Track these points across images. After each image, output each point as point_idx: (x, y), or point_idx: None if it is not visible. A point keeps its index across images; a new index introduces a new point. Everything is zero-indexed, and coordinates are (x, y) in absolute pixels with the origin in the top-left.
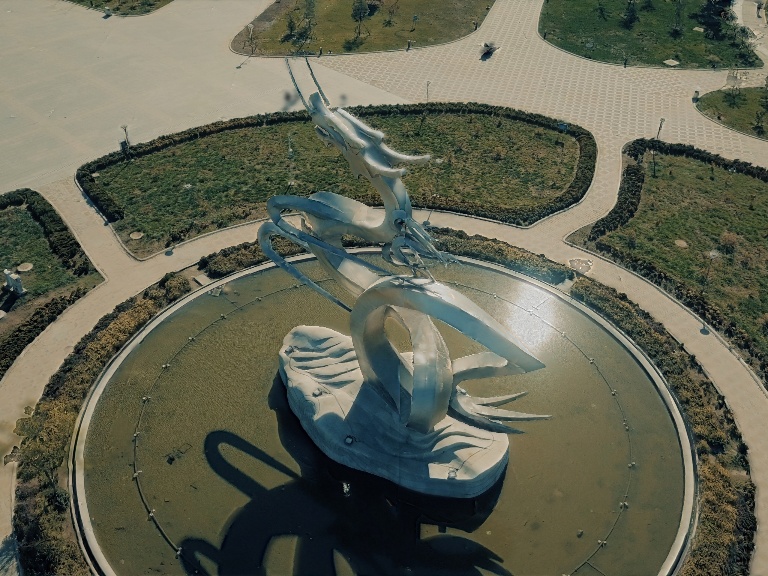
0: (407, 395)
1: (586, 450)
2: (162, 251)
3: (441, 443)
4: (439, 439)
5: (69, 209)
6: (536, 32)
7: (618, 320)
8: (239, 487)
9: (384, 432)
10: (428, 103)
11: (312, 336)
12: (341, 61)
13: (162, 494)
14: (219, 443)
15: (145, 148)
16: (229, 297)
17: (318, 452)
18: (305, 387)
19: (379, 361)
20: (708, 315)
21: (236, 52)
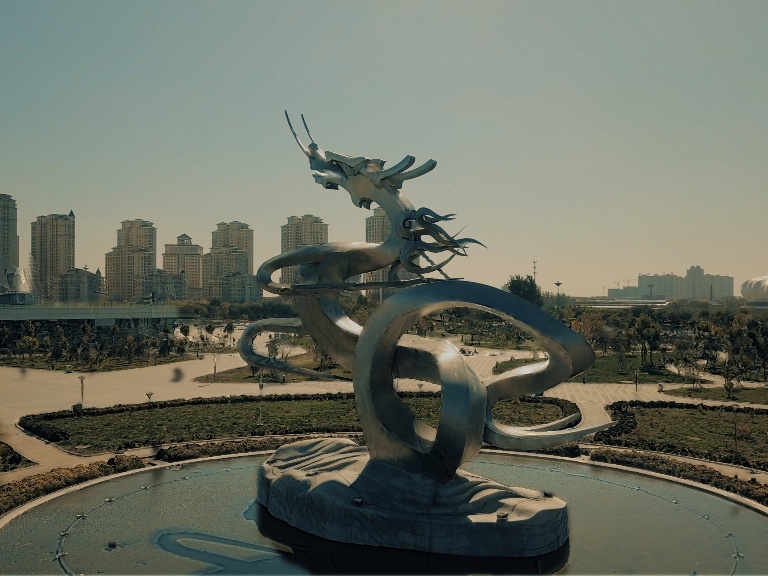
0: (429, 442)
1: (664, 530)
2: (112, 452)
3: (480, 494)
4: (476, 491)
5: (5, 437)
6: (492, 374)
7: (653, 465)
8: (207, 562)
9: (403, 495)
10: (398, 392)
11: (300, 444)
12: (305, 384)
13: (95, 568)
14: (178, 538)
15: (99, 410)
16: (191, 470)
17: (314, 539)
18: (295, 472)
19: (389, 416)
20: (752, 463)
21: (198, 381)
